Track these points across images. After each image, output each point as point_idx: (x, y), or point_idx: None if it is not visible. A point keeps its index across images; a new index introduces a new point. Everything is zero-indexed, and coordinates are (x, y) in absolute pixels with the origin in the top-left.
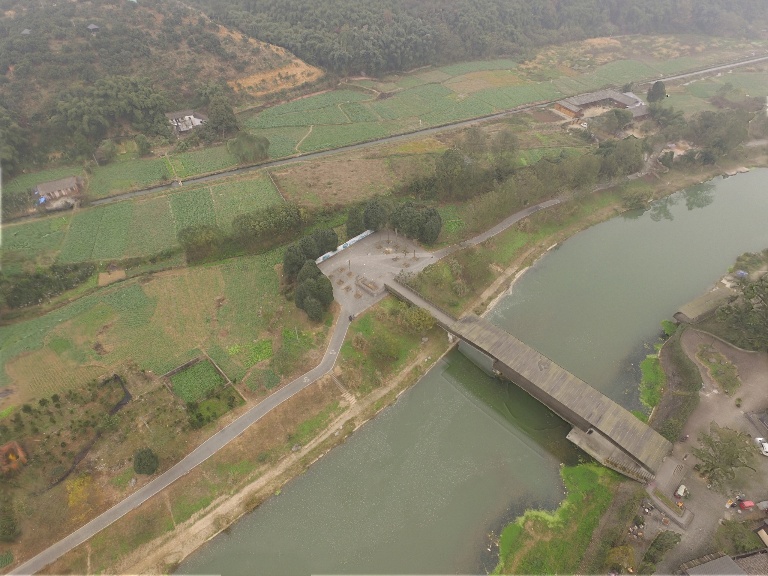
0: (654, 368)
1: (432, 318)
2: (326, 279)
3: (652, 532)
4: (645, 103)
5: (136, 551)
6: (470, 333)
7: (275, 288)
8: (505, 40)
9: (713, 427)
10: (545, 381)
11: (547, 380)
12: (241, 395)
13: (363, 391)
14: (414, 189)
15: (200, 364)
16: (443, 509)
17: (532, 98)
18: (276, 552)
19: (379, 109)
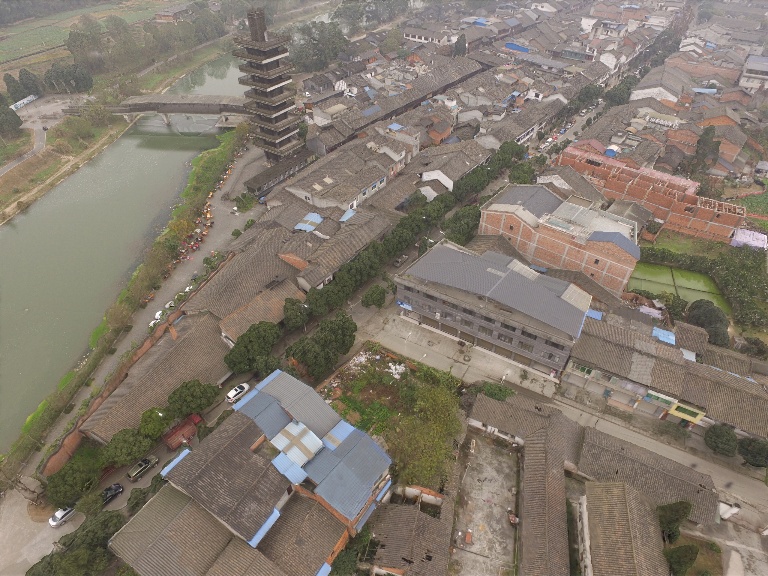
0: None
1: (106, 109)
2: (7, 107)
3: None
4: (219, 3)
5: None
6: (133, 101)
7: None
8: None
9: None
10: (187, 100)
11: (188, 100)
12: None
13: (76, 153)
14: None
15: None
16: (155, 167)
17: (137, 19)
18: (54, 211)
19: None
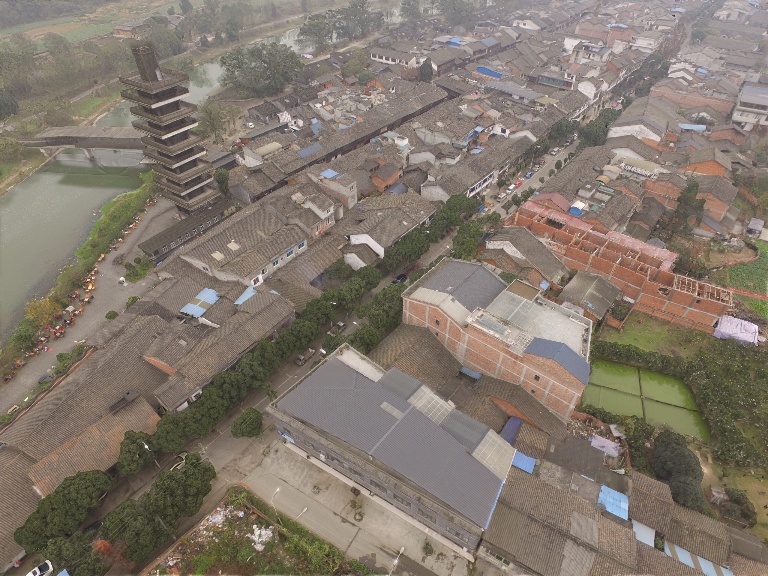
0: None
1: (19, 142)
2: None
3: None
4: (184, 16)
5: None
6: (49, 134)
7: None
8: (58, 1)
9: None
10: (108, 134)
11: (109, 133)
12: None
13: None
14: None
15: None
16: (58, 214)
17: (95, 33)
18: None
19: None
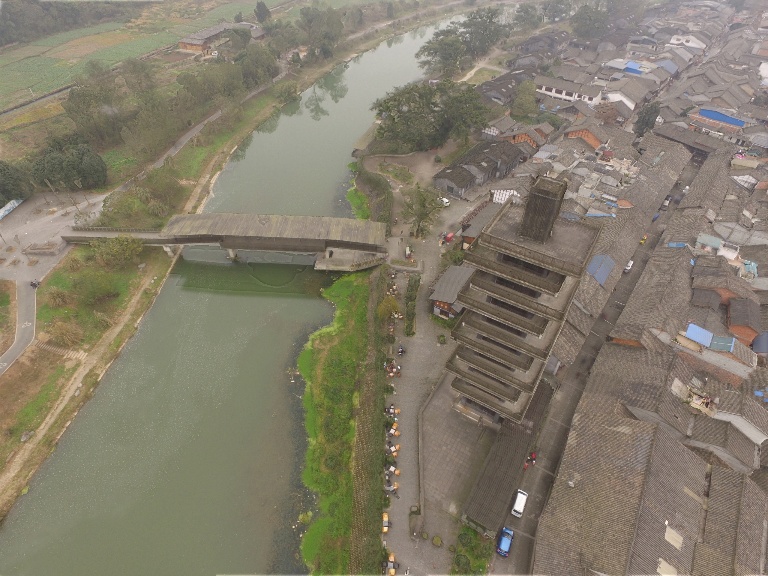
0: (356, 195)
1: (136, 239)
2: None
3: (403, 287)
4: (259, 25)
5: None
6: (182, 229)
7: None
8: (97, 3)
9: (402, 191)
10: (271, 230)
11: (272, 229)
12: None
13: (90, 341)
14: (56, 149)
15: None
16: (235, 381)
17: (154, 46)
18: (55, 542)
19: None
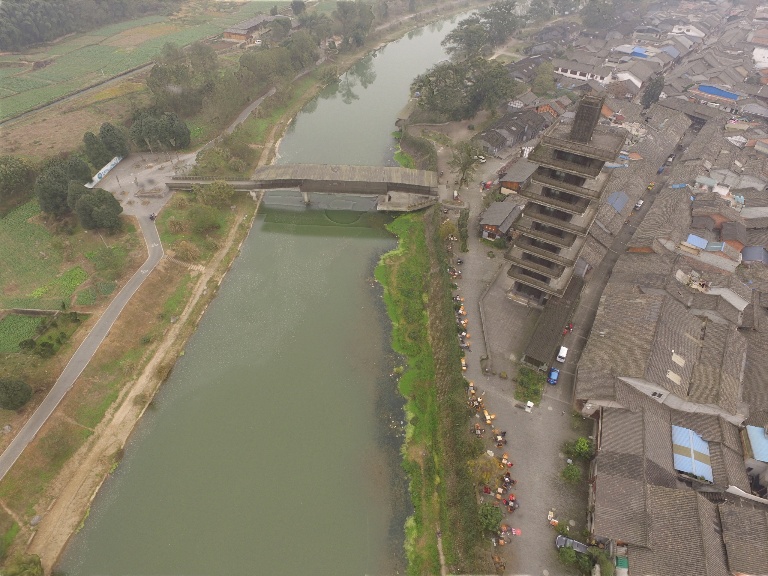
0: (403, 156)
1: (229, 185)
2: (104, 190)
3: (455, 220)
4: (294, 17)
5: (63, 470)
6: (268, 176)
7: (45, 234)
8: None
9: (451, 144)
10: (343, 176)
11: (344, 175)
12: (81, 312)
13: (206, 258)
14: (138, 119)
15: (3, 322)
16: (327, 285)
17: (200, 36)
18: (214, 383)
19: (44, 76)
